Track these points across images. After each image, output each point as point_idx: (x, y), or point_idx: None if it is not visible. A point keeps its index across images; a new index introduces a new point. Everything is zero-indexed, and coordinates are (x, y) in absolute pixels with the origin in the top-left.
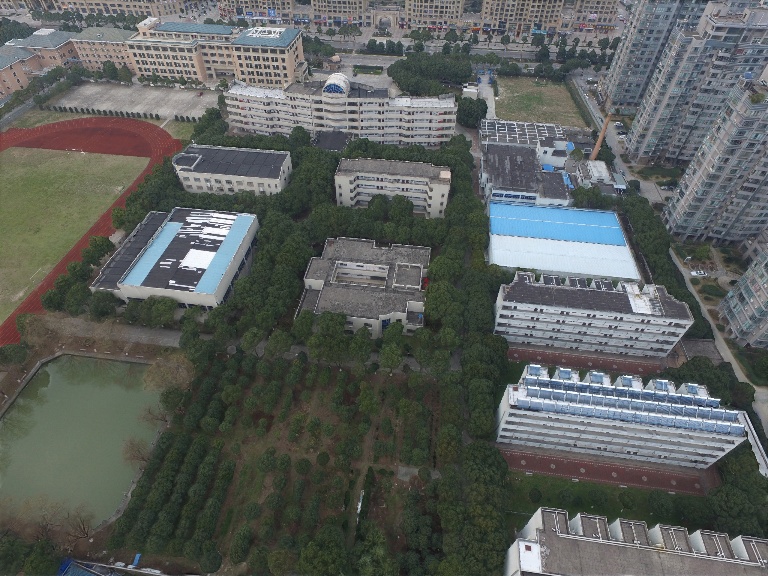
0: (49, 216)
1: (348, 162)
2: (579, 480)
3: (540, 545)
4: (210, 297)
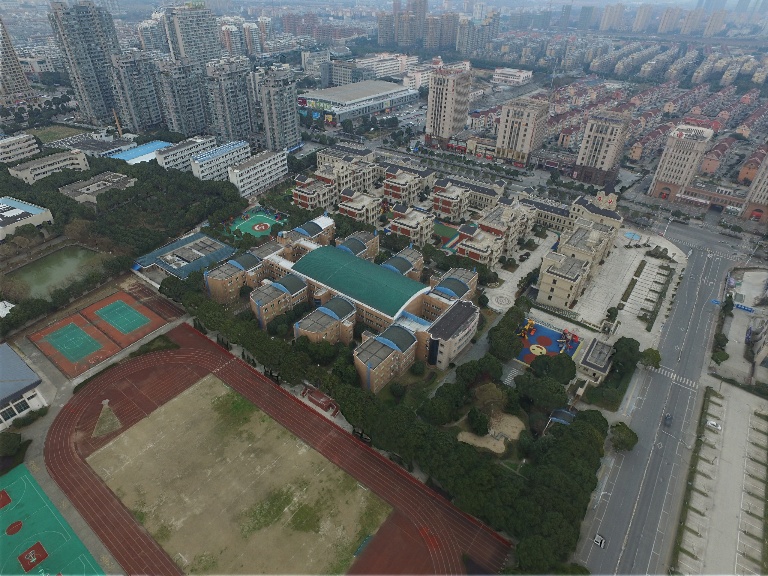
0: None
1: (15, 168)
2: None
3: (235, 169)
4: (48, 213)
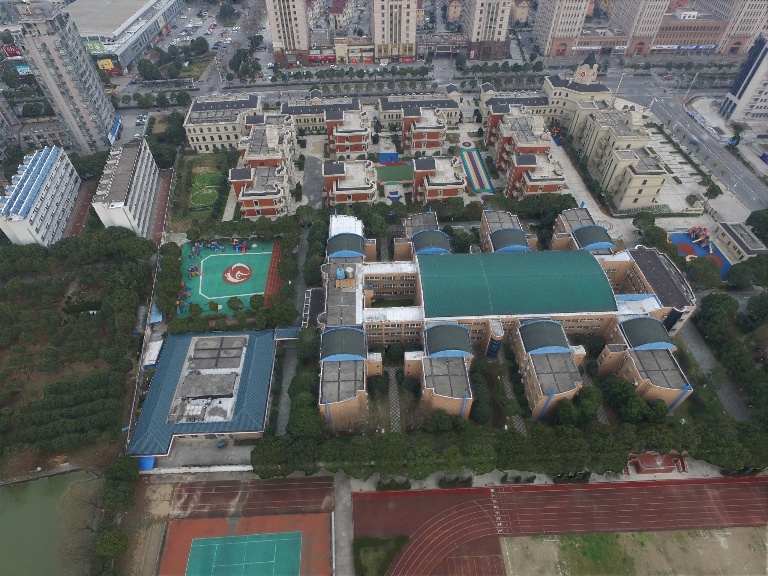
0: None
1: None
2: (84, 225)
3: (111, 202)
4: None
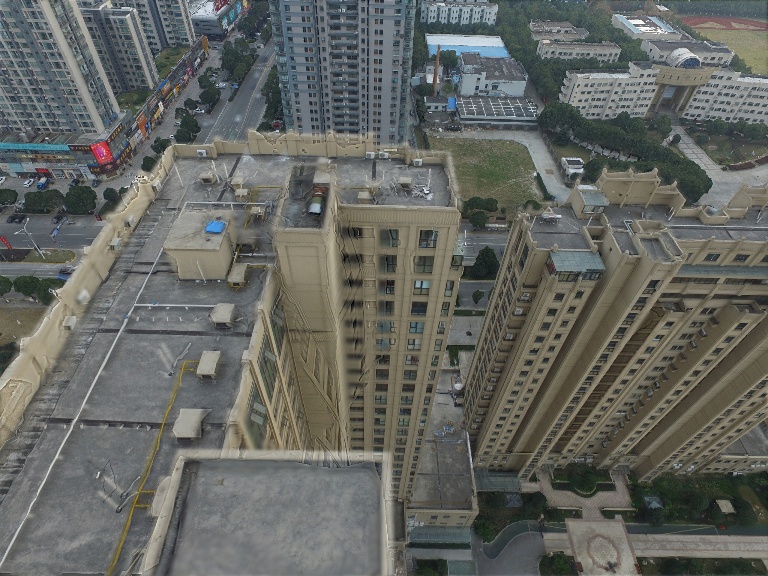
0: (766, 64)
1: None
2: None
3: None
4: None
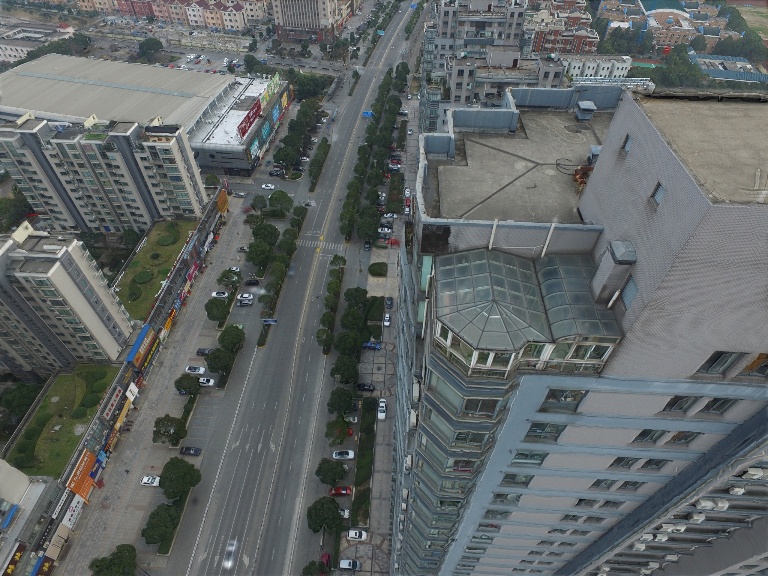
0: None
1: None
2: None
3: None
4: None
